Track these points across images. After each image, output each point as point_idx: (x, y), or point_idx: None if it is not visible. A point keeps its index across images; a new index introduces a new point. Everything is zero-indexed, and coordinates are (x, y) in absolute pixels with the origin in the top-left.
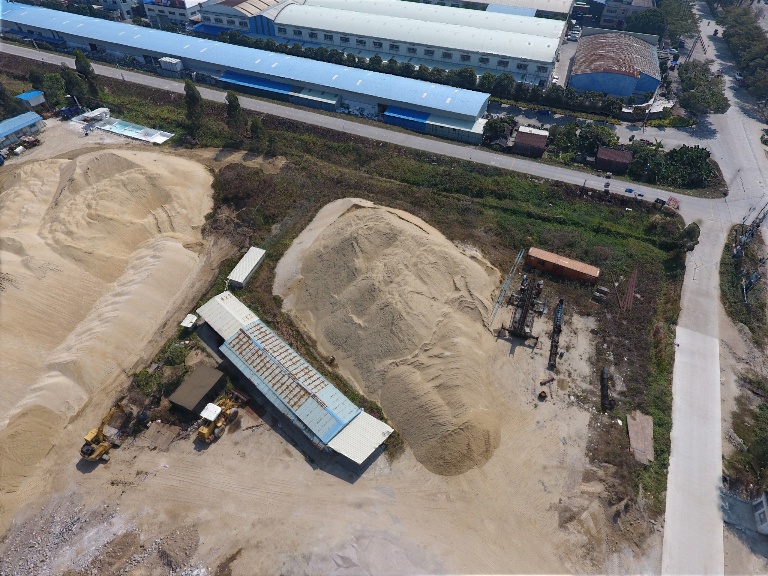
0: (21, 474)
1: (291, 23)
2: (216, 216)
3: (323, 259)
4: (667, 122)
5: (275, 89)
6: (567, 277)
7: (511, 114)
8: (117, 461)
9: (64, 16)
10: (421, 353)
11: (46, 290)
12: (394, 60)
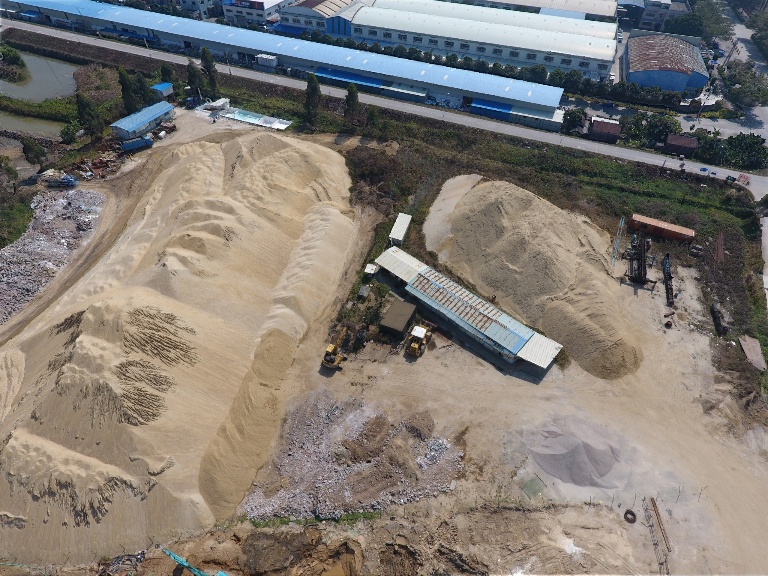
0: (279, 378)
1: (368, 24)
2: (359, 189)
3: (472, 220)
4: (718, 114)
5: (368, 83)
6: (667, 237)
7: (579, 106)
8: (349, 369)
9: (156, 16)
10: (569, 291)
11: (258, 242)
12: (470, 58)
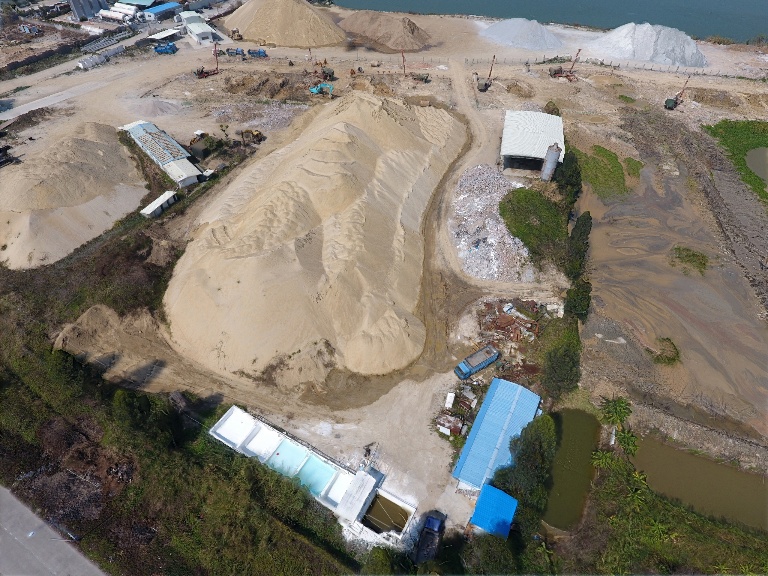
0: None
1: None
2: (172, 247)
3: (96, 175)
4: None
5: None
6: None
7: None
8: None
9: None
10: None
11: None
12: None
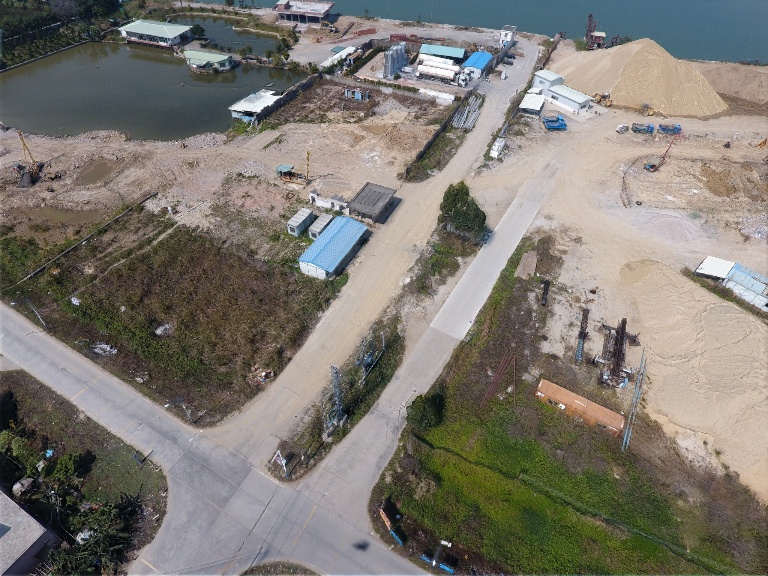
0: None
1: None
2: None
3: None
4: None
5: None
6: None
7: None
8: None
9: None
10: None
11: None
12: None
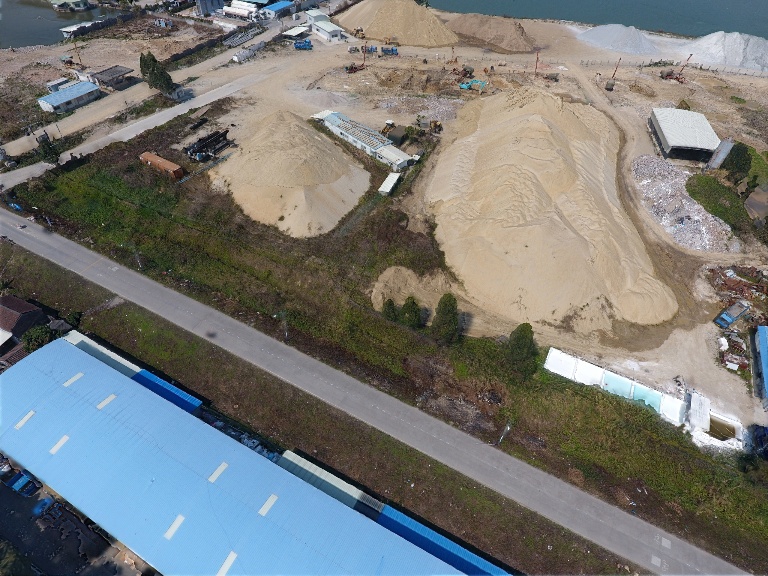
0: None
1: None
2: (426, 220)
3: None
4: None
5: (416, 530)
6: None
7: None
8: None
9: None
10: None
11: None
12: None
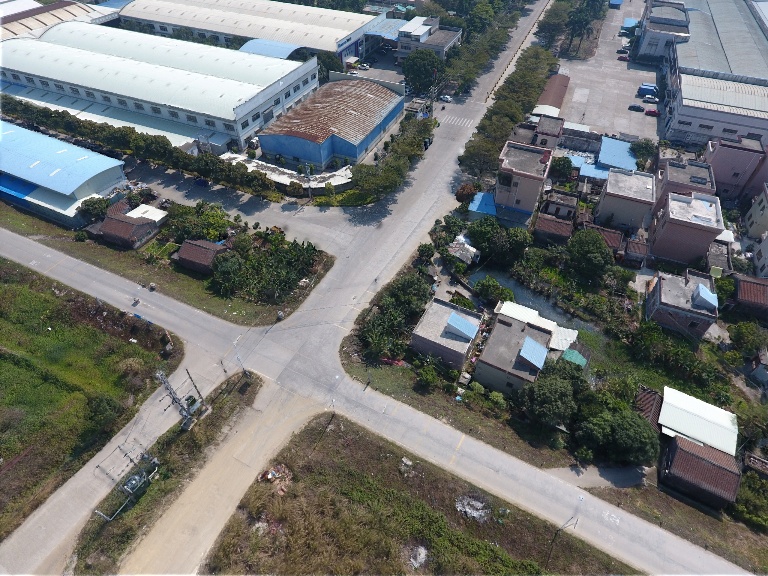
0: None
1: None
2: None
3: None
4: (339, 199)
5: None
6: None
7: (164, 184)
8: None
9: None
10: None
11: None
12: (62, 113)
